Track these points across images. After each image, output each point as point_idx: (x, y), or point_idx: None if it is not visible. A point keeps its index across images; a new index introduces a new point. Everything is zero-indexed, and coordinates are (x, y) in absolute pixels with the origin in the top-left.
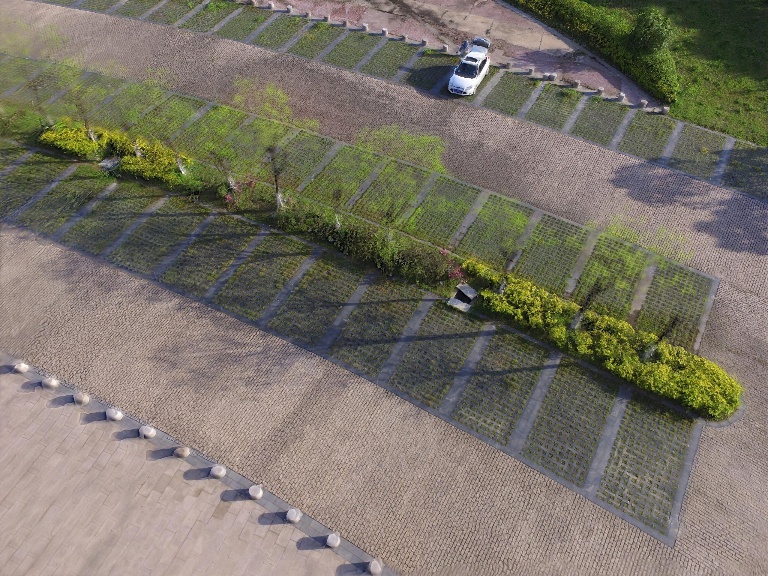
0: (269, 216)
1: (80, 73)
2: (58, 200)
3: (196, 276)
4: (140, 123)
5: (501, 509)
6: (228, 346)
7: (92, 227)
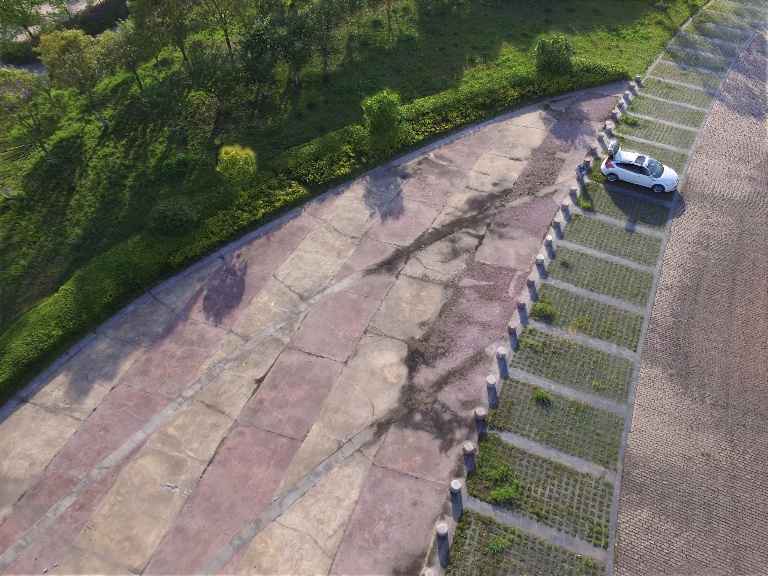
0: None
1: None
2: None
3: None
4: None
5: None
6: None
7: None
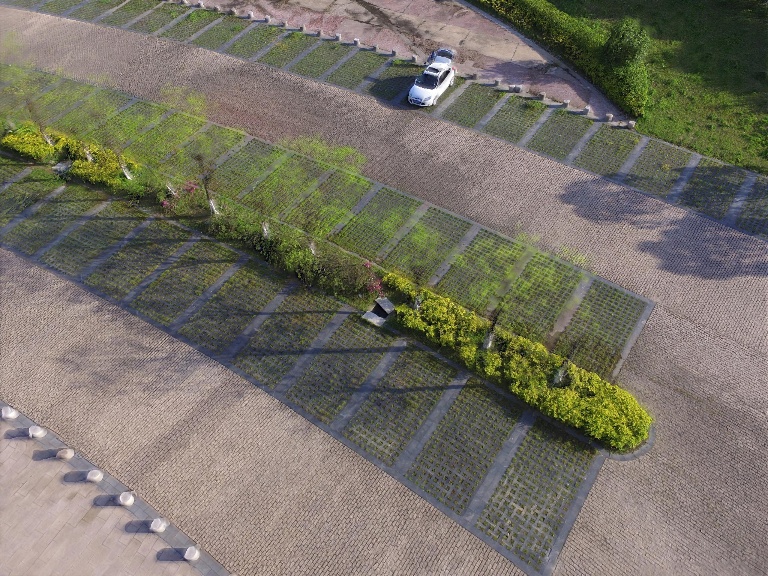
0: (202, 222)
1: (56, 79)
2: (8, 201)
3: (120, 279)
4: (101, 128)
5: (373, 533)
6: (135, 350)
7: (34, 228)
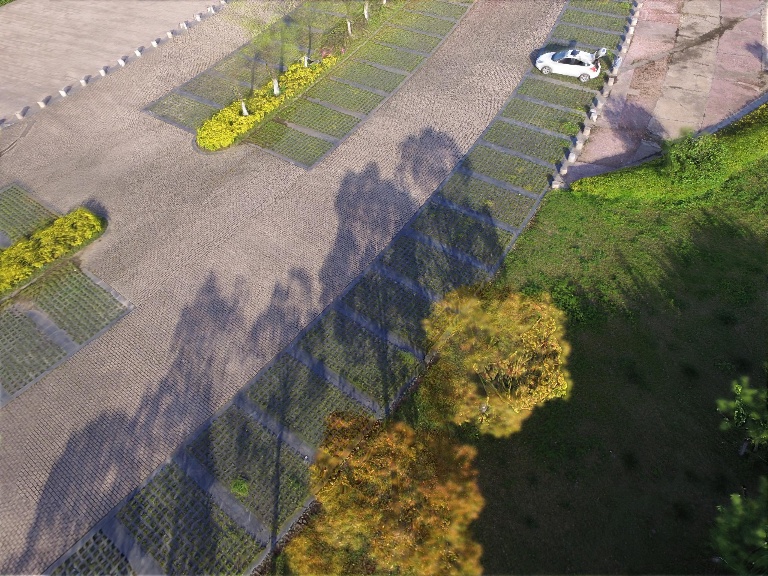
0: None
1: None
2: None
3: None
4: None
5: None
6: (288, 0)
7: None
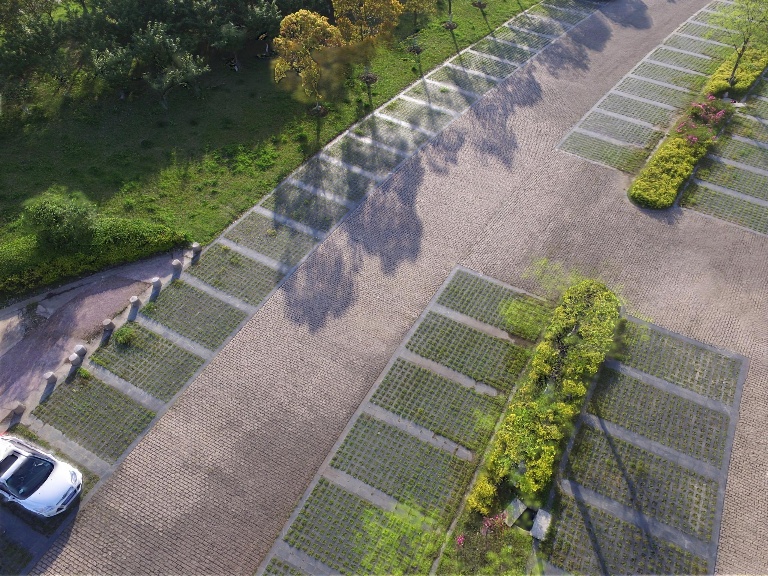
0: None
1: None
2: None
3: None
4: None
5: None
6: None
7: None
